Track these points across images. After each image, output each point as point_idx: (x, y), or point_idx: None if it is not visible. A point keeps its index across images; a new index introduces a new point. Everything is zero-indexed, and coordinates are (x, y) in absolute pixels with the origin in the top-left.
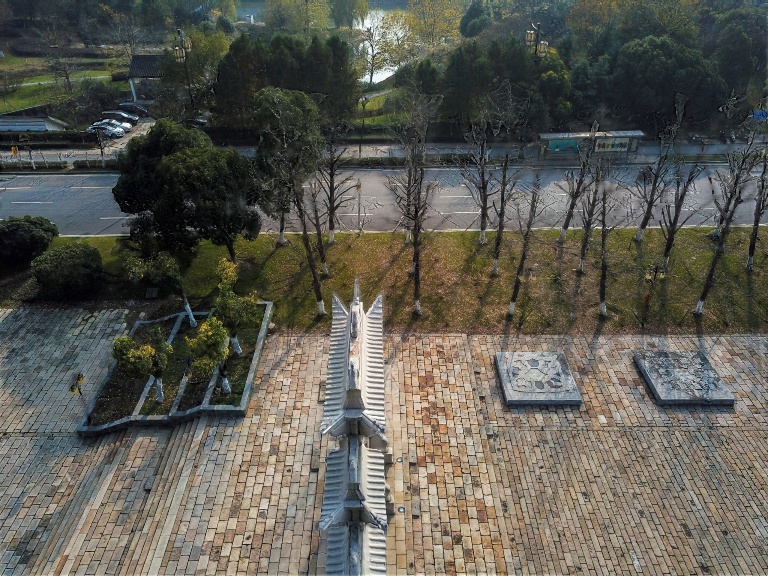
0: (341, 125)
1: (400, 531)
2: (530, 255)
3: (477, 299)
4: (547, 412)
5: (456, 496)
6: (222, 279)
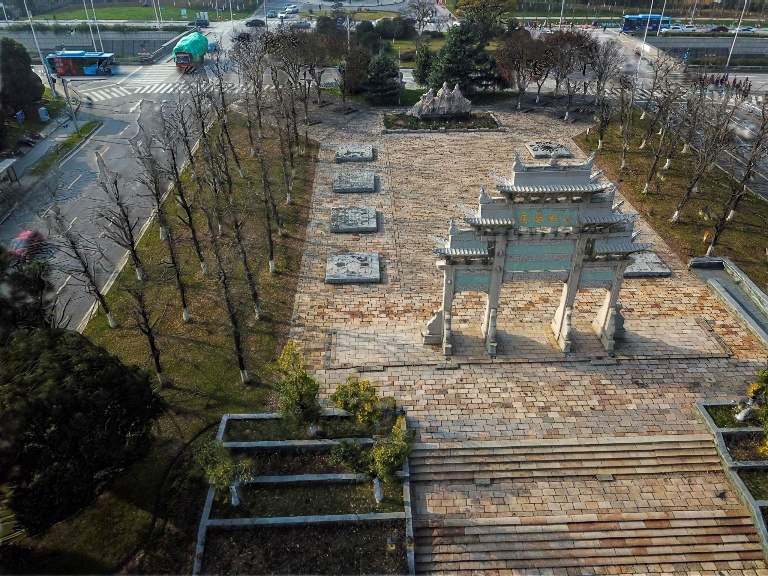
0: (16, 242)
1: (499, 325)
2: (184, 254)
3: (247, 285)
4: (385, 268)
5: (465, 305)
6: (297, 366)
